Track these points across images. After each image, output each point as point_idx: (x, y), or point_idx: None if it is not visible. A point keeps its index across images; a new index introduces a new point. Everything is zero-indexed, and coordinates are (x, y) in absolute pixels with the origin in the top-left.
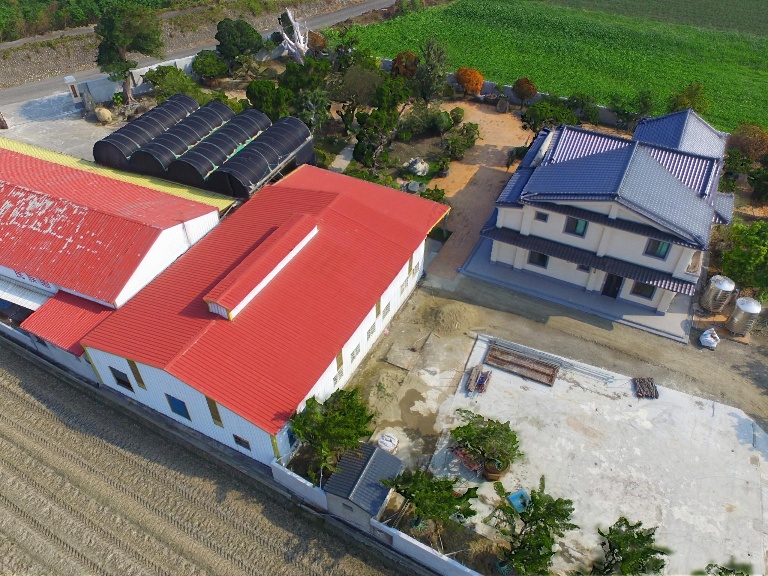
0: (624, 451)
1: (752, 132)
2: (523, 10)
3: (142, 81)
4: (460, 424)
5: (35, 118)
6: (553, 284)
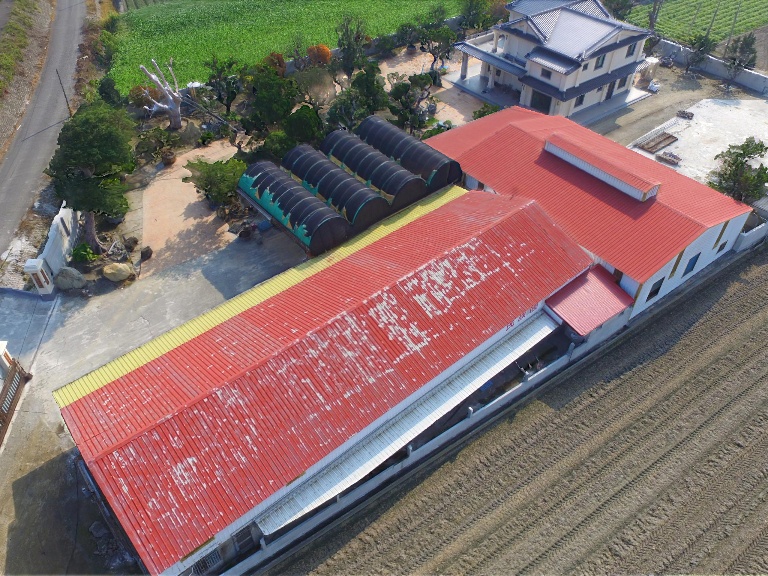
0: (729, 136)
1: (497, 1)
2: (201, 7)
3: (70, 225)
4: (702, 175)
5: (31, 345)
6: (588, 112)
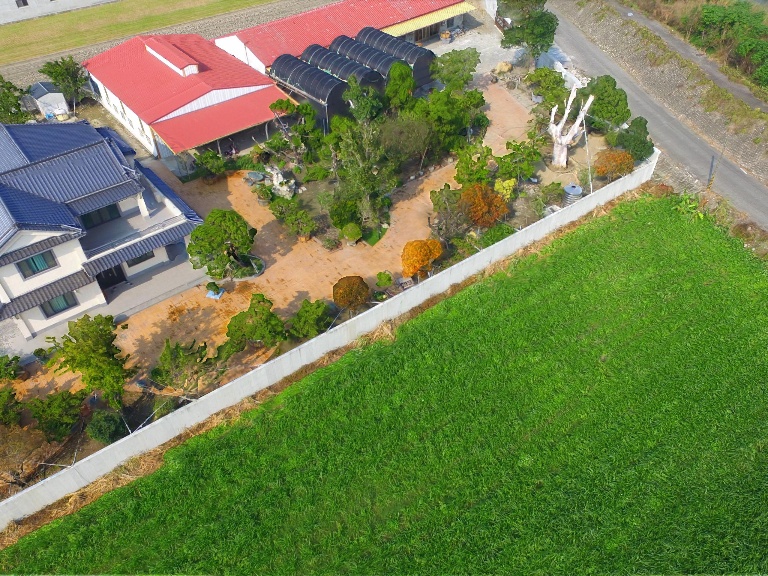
0: None
1: None
2: None
3: None
4: None
5: (523, 50)
6: None
